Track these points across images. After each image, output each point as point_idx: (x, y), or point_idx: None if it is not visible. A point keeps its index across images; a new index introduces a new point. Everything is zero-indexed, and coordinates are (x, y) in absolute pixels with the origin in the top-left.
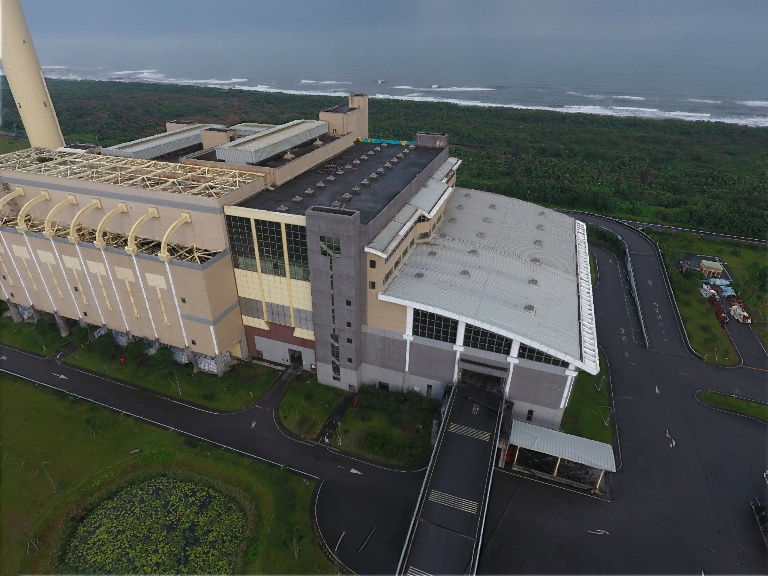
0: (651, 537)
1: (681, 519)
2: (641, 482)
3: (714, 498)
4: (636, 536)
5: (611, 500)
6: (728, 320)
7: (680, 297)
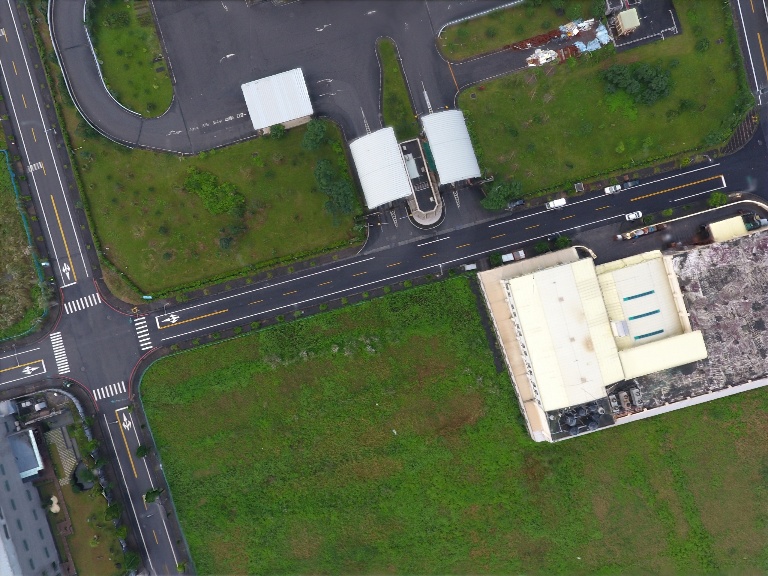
0: (239, 30)
1: (261, 41)
2: (274, 18)
3: (289, 55)
4: (235, 23)
5: (249, 7)
6: (521, 48)
7: (527, 1)
